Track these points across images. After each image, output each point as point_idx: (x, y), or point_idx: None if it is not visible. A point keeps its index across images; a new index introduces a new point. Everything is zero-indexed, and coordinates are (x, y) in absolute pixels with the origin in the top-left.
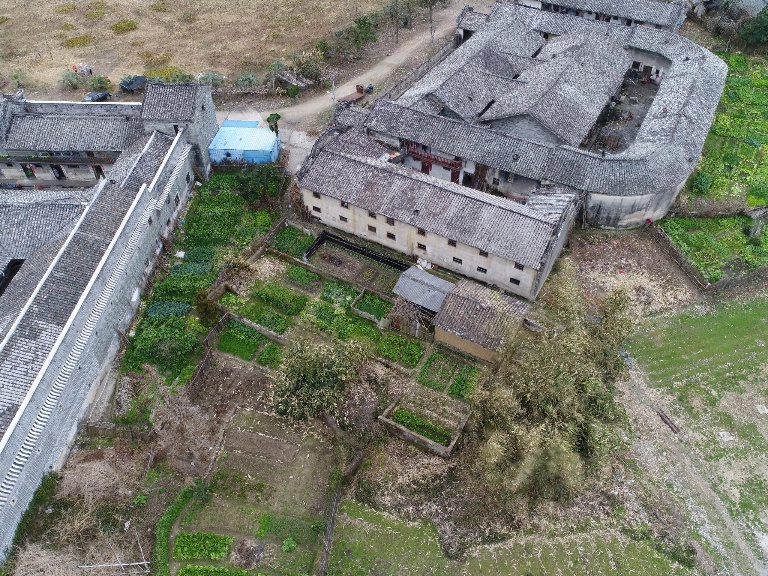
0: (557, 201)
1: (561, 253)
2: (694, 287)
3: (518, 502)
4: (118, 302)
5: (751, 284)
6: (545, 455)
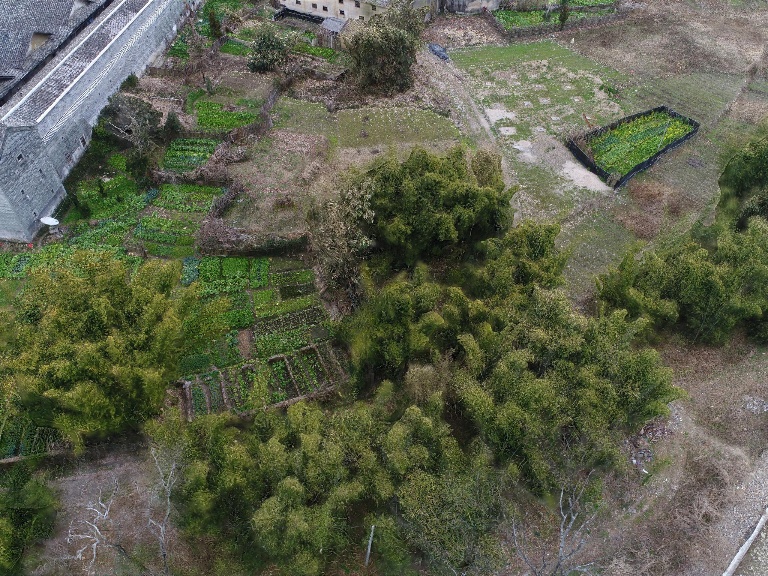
0: None
1: (426, 21)
2: (500, 36)
3: (369, 97)
4: (166, 22)
5: (535, 36)
6: (371, 47)
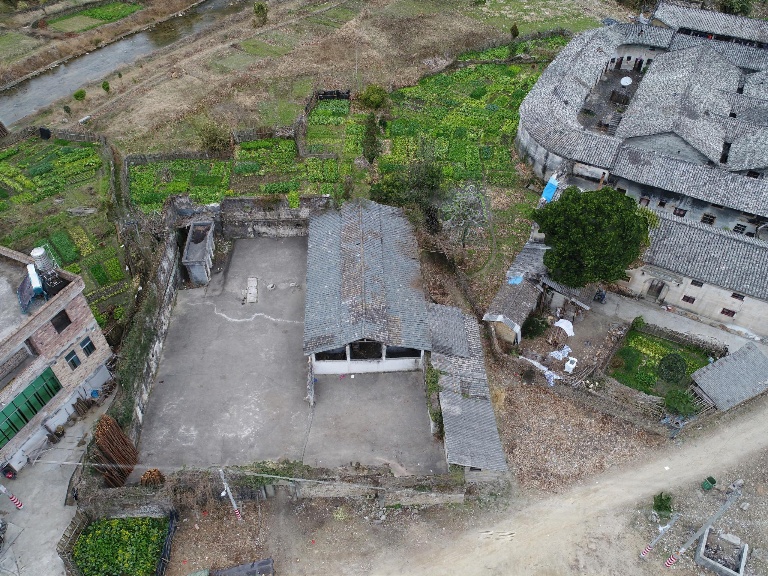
0: None
1: None
2: None
3: None
4: None
5: None
6: None
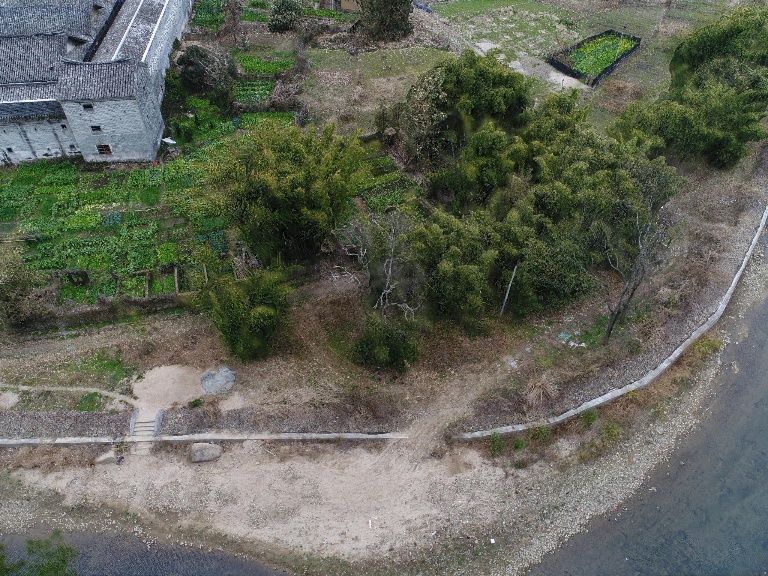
0: None
1: None
2: None
3: None
4: None
5: None
6: None
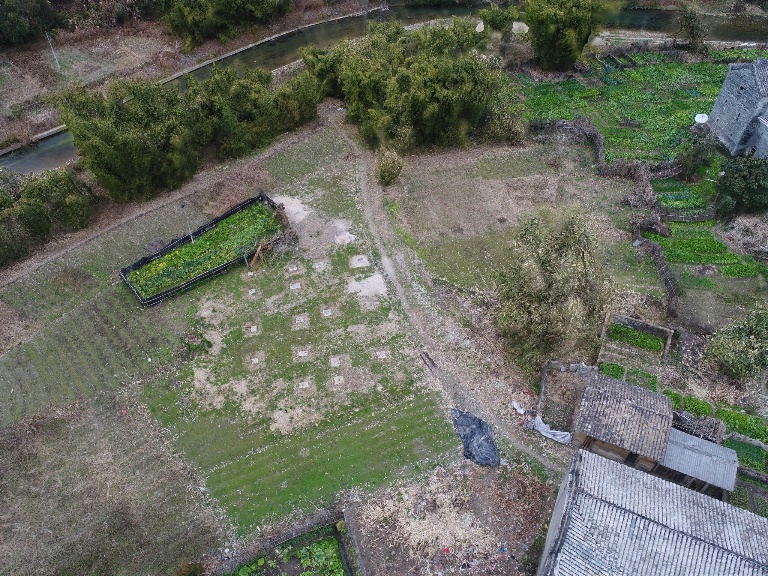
0: (579, 571)
1: (535, 574)
2: None
3: None
4: None
5: None
6: None
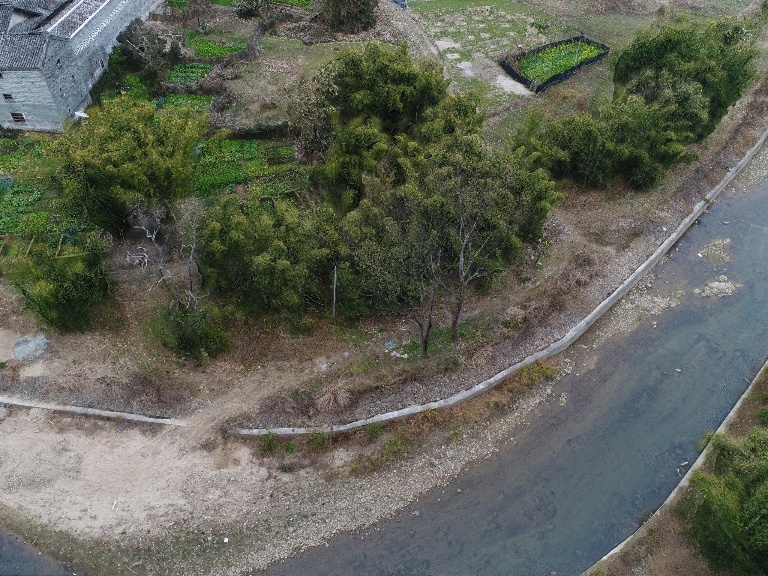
0: None
1: None
2: None
3: (339, 34)
4: None
5: None
6: None
